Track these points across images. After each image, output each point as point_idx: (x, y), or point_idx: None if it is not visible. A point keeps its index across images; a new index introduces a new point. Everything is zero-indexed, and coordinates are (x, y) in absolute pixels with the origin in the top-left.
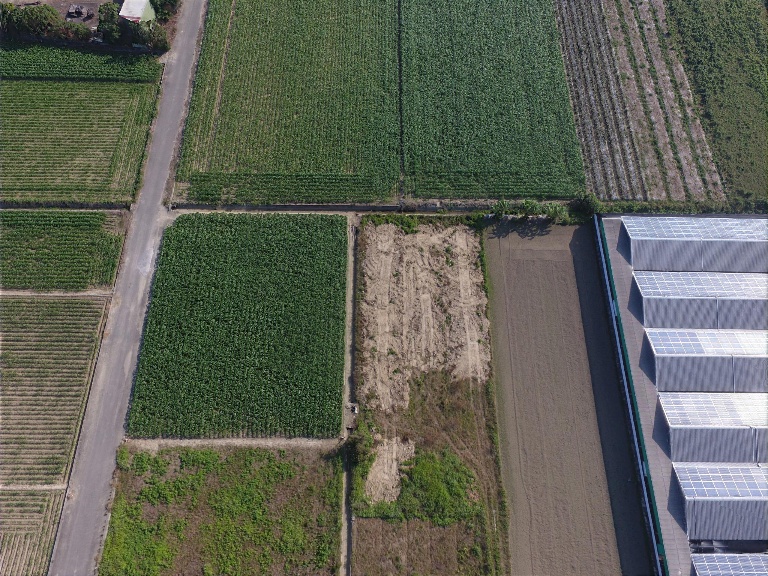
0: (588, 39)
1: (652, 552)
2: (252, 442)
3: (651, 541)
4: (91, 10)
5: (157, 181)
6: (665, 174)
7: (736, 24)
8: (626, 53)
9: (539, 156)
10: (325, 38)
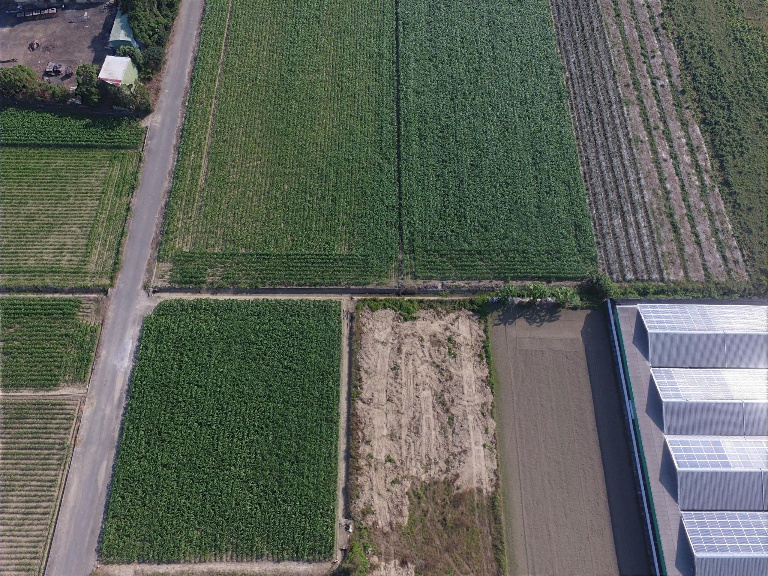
0: (598, 97)
1: None
2: (236, 567)
3: None
4: (70, 69)
5: (137, 262)
6: (682, 250)
7: (755, 80)
8: (639, 113)
9: (547, 231)
10: (319, 98)
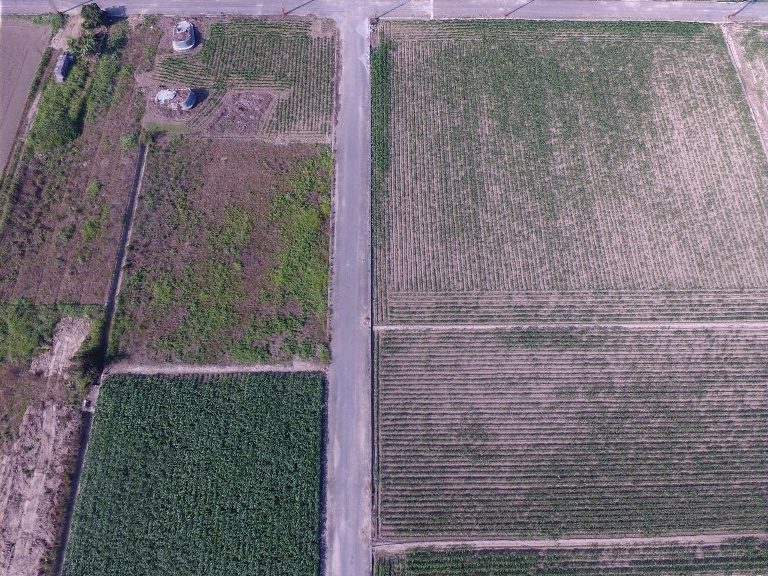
0: None
1: None
2: (198, 370)
3: None
4: None
5: None
6: None
7: None
8: None
9: None
10: None
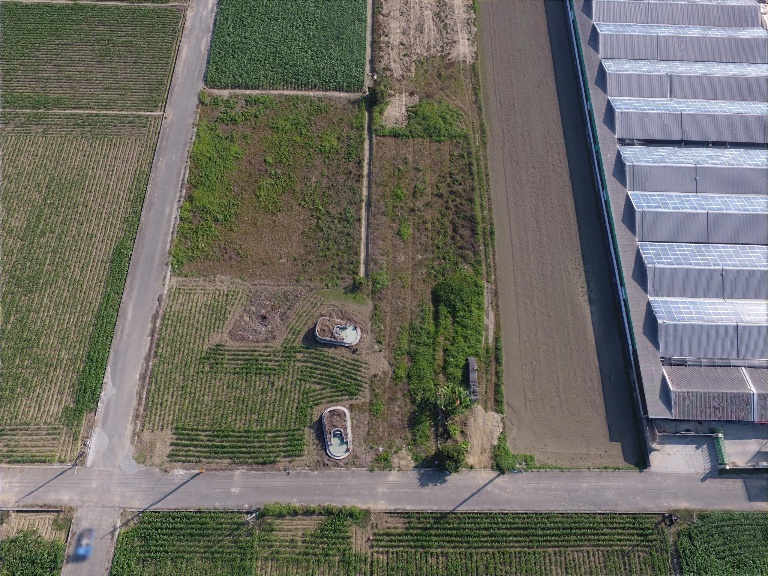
0: None
1: (592, 157)
2: (298, 92)
3: (591, 150)
4: None
5: None
6: None
7: None
8: None
9: None
10: None
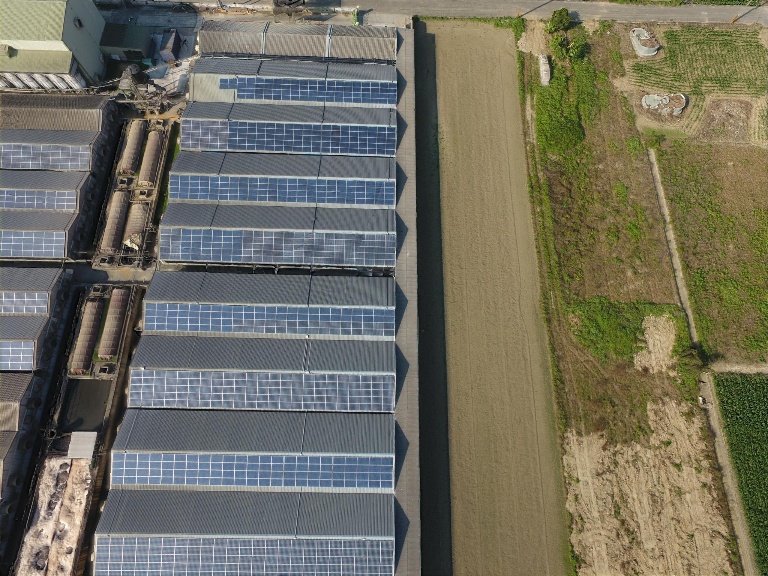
0: None
1: None
2: None
3: None
4: None
5: None
6: None
7: None
8: None
9: None
10: None
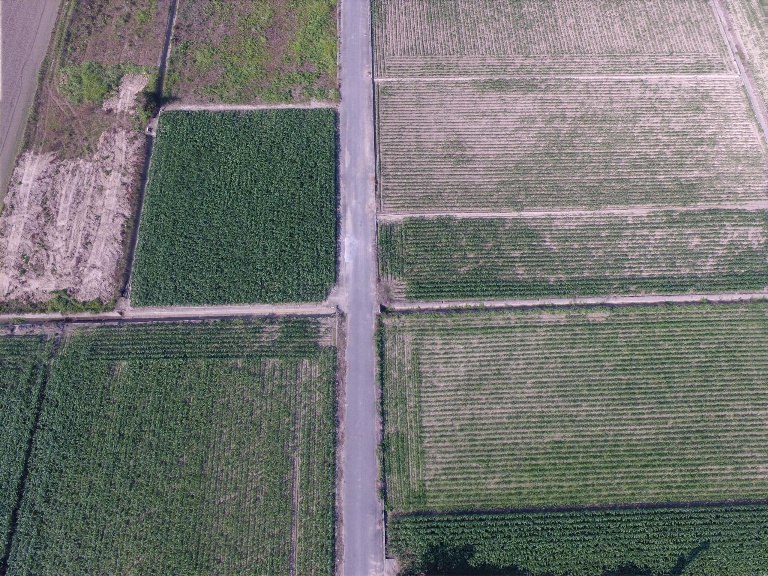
0: None
1: None
2: (236, 107)
3: None
4: None
5: (357, 345)
6: None
7: None
8: None
9: None
10: None
